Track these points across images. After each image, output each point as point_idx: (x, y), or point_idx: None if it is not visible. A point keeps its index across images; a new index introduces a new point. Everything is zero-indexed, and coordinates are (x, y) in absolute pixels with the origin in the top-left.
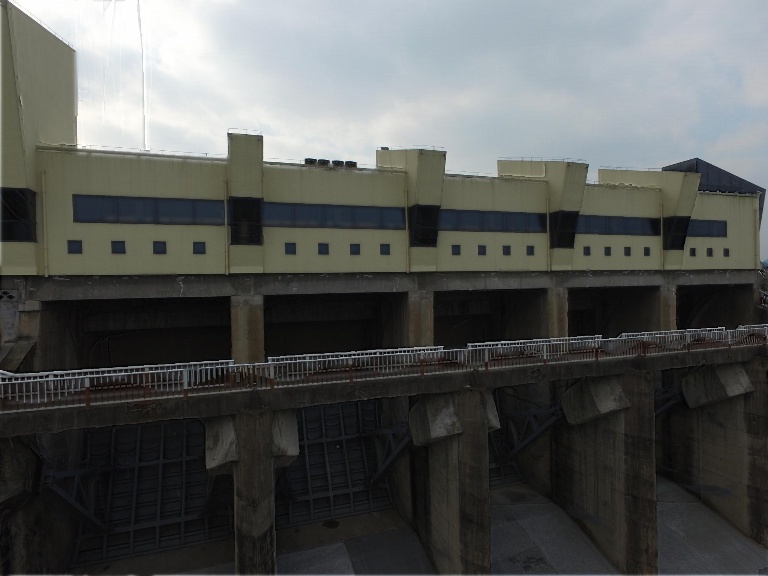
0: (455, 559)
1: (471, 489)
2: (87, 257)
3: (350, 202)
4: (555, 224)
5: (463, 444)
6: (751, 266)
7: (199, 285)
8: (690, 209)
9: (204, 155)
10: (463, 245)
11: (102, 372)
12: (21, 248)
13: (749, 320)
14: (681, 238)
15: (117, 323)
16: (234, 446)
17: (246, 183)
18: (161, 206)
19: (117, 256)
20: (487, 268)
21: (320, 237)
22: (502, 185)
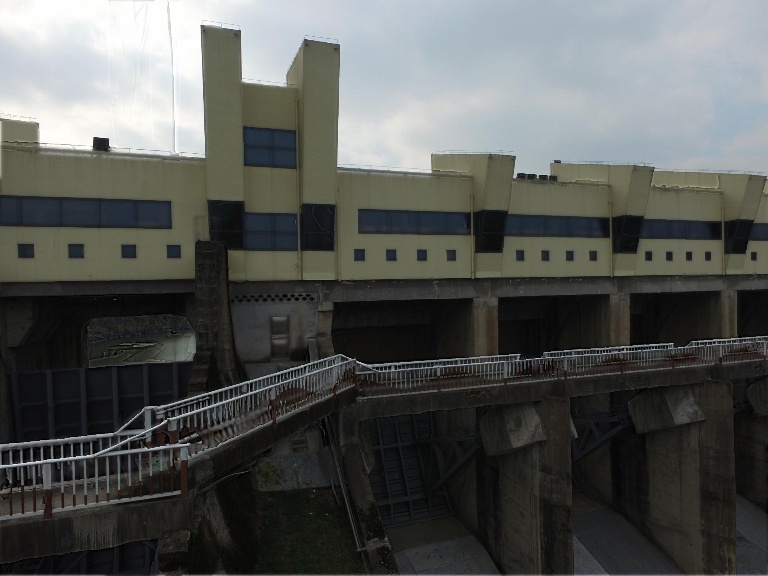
0: (693, 533)
1: (716, 470)
2: (368, 264)
3: (566, 213)
4: (731, 232)
5: (706, 430)
6: None
7: (449, 288)
8: None
9: (454, 173)
10: (654, 251)
11: (427, 364)
12: (326, 256)
13: None
14: None
15: (341, 322)
16: (540, 428)
17: (497, 198)
18: (422, 218)
19: (390, 263)
20: (673, 272)
21: (543, 245)
22: (685, 196)
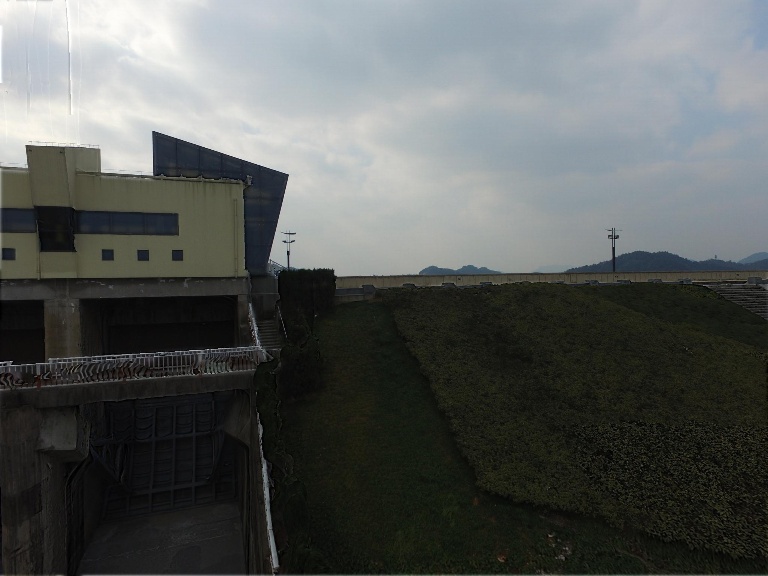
0: None
1: None
2: None
3: None
4: None
5: None
6: (228, 273)
7: None
8: (62, 197)
9: None
10: None
11: None
12: None
13: (240, 342)
14: (65, 236)
15: None
16: None
17: None
18: None
19: None
20: None
21: None
22: None
